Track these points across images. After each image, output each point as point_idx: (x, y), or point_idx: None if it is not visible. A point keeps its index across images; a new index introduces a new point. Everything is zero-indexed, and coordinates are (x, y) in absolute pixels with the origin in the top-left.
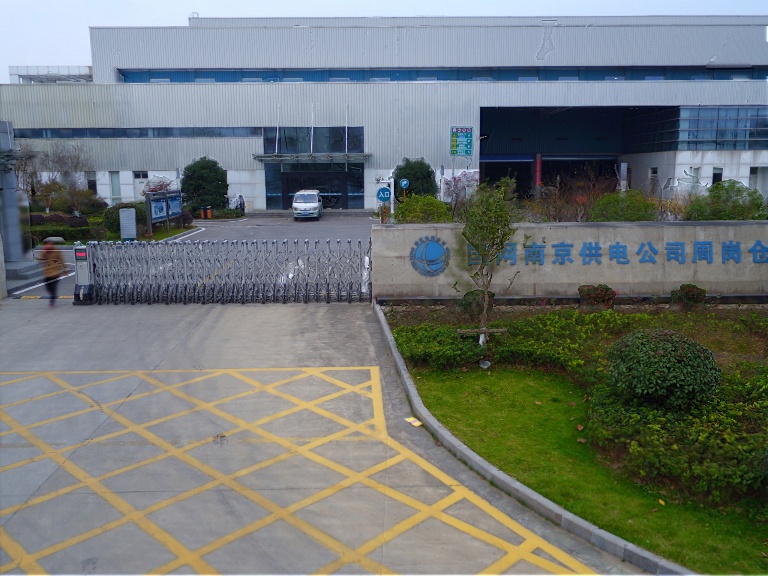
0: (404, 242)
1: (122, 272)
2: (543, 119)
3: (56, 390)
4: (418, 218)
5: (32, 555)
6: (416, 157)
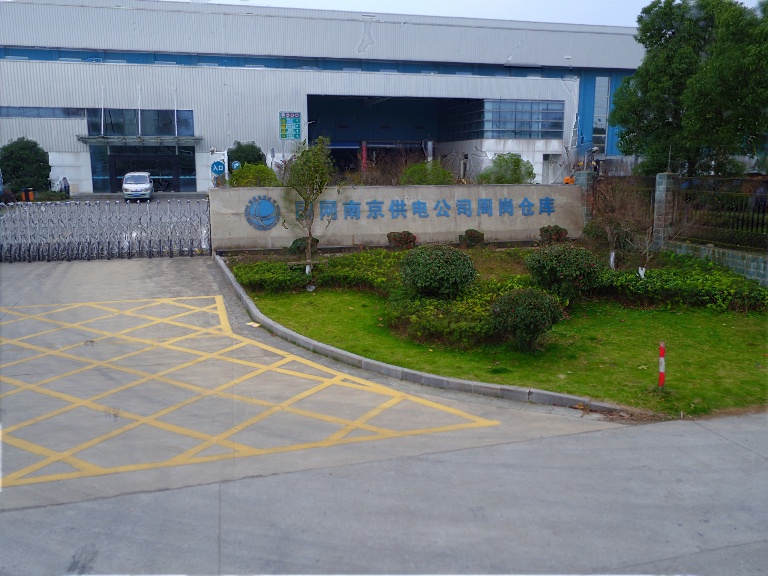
0: (239, 201)
1: None
2: (367, 109)
3: None
4: (251, 183)
5: None
6: None
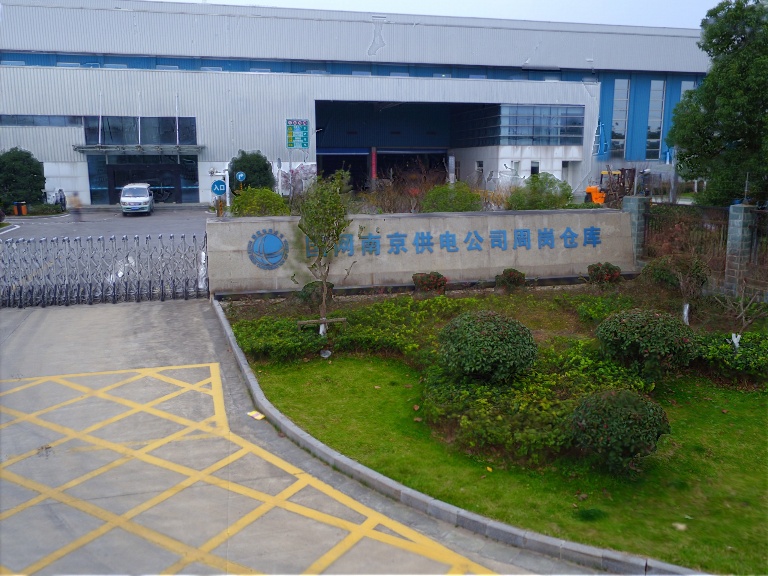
0: (241, 236)
1: None
2: (377, 113)
3: None
4: (255, 211)
5: None
6: (252, 149)
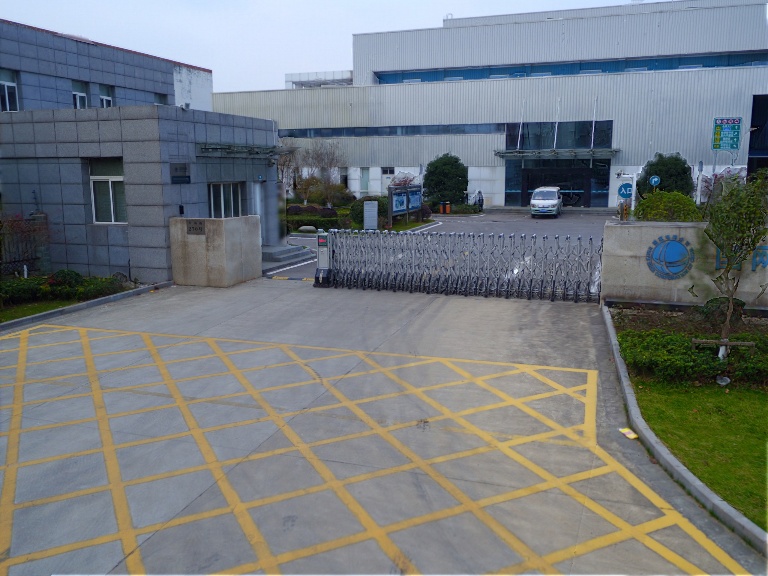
0: (640, 241)
1: (357, 259)
2: None
3: (287, 361)
4: (661, 216)
5: (244, 504)
6: (671, 152)
